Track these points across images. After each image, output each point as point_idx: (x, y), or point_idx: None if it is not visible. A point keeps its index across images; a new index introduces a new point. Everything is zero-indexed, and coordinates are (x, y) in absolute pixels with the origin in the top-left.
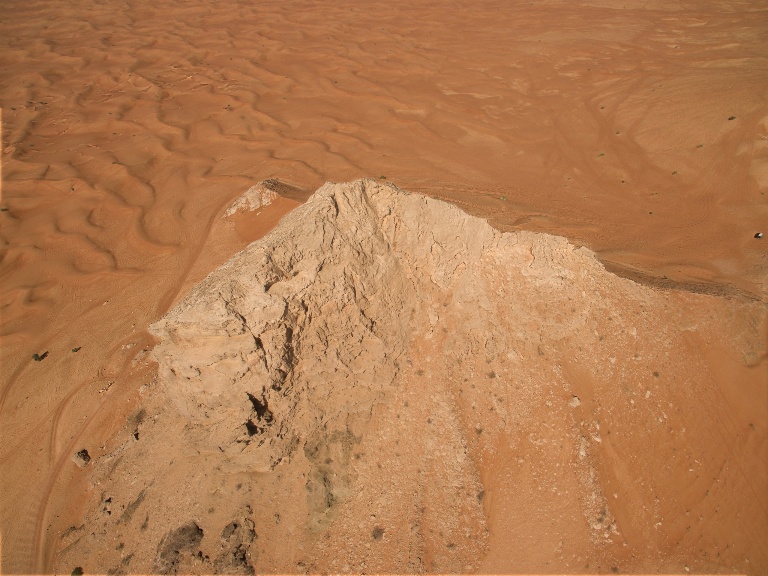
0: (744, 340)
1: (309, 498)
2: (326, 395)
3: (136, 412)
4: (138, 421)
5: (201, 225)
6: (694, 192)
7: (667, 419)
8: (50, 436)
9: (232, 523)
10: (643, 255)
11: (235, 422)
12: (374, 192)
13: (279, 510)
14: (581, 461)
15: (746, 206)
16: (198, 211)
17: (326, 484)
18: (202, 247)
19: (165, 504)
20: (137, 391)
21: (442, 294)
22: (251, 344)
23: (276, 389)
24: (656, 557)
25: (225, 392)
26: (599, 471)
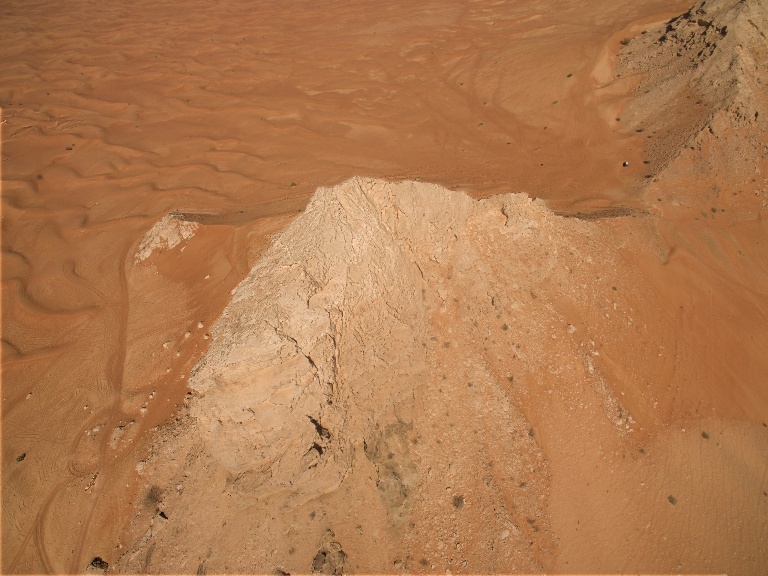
0: (655, 245)
1: (383, 498)
2: (370, 395)
3: (145, 493)
4: (153, 501)
5: (111, 279)
6: (566, 141)
7: (633, 321)
8: (40, 562)
9: (320, 553)
10: (554, 200)
11: (299, 450)
12: (369, 187)
13: (359, 521)
14: (592, 375)
15: (607, 144)
16: (98, 265)
17: (397, 478)
18: (127, 301)
19: (235, 568)
20: (134, 472)
21: (443, 269)
22: (306, 364)
23: (329, 403)
24: (663, 430)
25: (286, 423)
26: (606, 378)
